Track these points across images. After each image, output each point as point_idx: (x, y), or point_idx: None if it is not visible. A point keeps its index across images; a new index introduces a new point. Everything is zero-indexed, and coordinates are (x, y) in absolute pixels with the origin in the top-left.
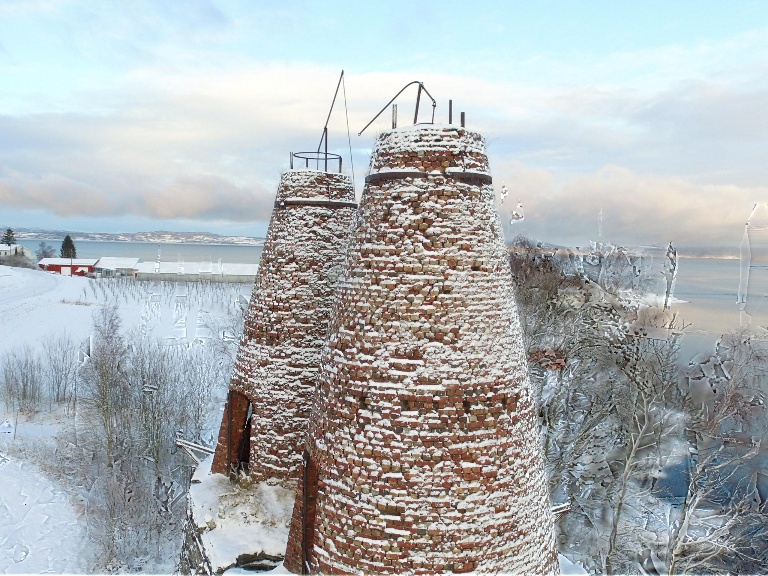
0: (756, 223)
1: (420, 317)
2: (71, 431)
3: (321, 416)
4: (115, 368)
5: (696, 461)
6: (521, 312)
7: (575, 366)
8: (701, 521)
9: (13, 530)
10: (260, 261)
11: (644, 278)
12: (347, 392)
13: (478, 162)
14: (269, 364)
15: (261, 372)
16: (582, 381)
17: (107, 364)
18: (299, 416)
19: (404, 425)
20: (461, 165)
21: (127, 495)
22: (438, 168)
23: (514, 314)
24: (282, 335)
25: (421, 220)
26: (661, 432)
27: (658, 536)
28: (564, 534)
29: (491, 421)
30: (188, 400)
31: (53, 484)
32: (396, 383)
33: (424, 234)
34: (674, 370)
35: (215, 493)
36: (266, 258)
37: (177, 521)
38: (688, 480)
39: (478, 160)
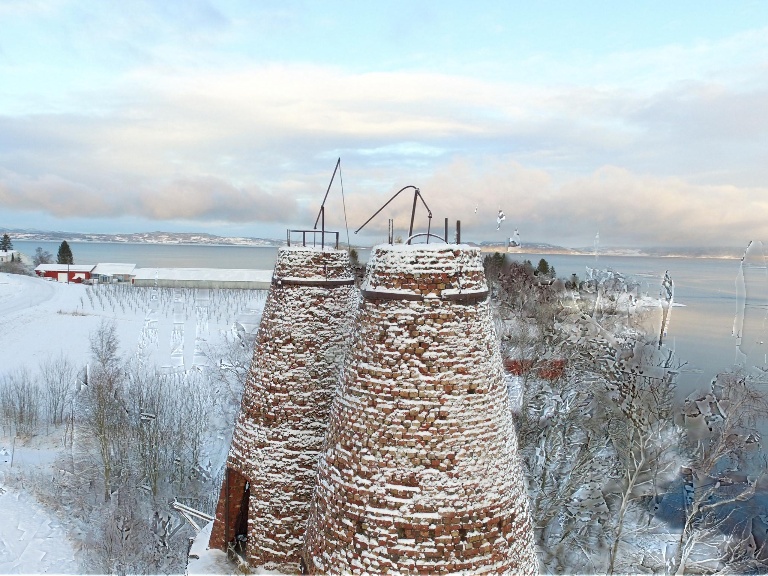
0: (751, 261)
1: (416, 443)
2: (68, 460)
3: (318, 533)
4: (112, 396)
5: (692, 499)
6: (518, 344)
7: (572, 398)
8: (697, 564)
9: (10, 568)
10: (257, 338)
11: (640, 305)
12: (344, 514)
13: (474, 280)
14: (266, 446)
15: (258, 454)
16: (579, 417)
17: (104, 392)
18: (296, 500)
19: (401, 554)
20: (457, 286)
21: (125, 533)
22: (434, 291)
23: (510, 429)
24: (279, 417)
25: (417, 344)
26: (657, 469)
27: (654, 572)
28: (561, 566)
29: (487, 547)
30: (185, 429)
31: (50, 517)
32: (393, 510)
33: (420, 358)
34: (670, 408)
35: (213, 575)
36: (263, 336)
37: (175, 554)
38: (684, 517)
39: (474, 278)
